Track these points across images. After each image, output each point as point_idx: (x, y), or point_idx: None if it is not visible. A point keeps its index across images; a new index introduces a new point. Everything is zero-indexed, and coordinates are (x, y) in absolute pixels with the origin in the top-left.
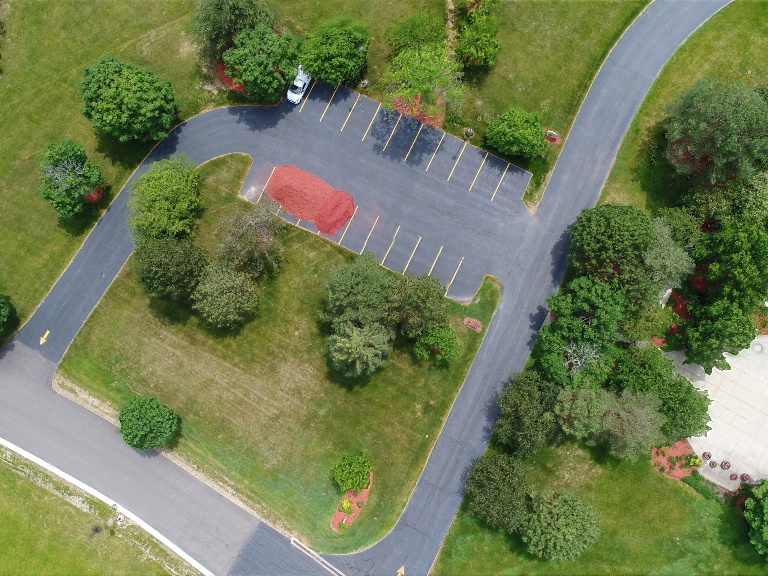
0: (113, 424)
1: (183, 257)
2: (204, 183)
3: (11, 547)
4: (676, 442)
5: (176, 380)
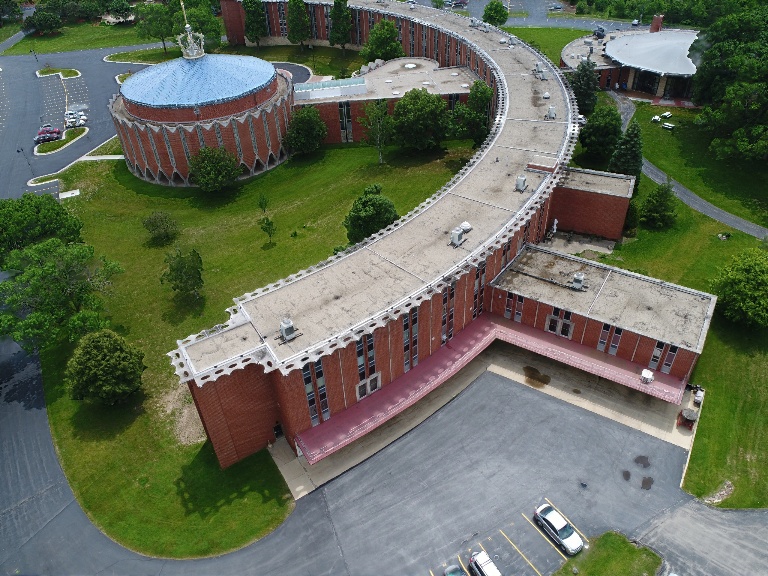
0: None
1: None
2: None
3: None
4: None
5: None
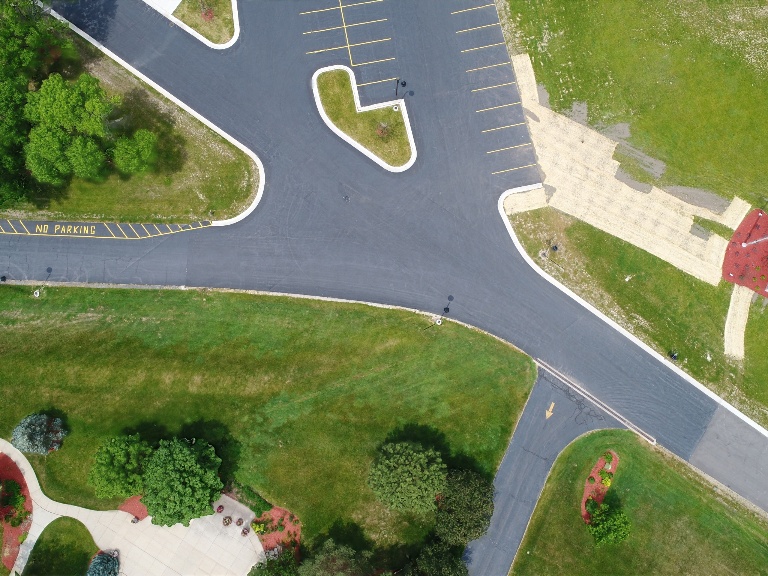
0: None
1: None
2: None
3: None
4: None
5: None
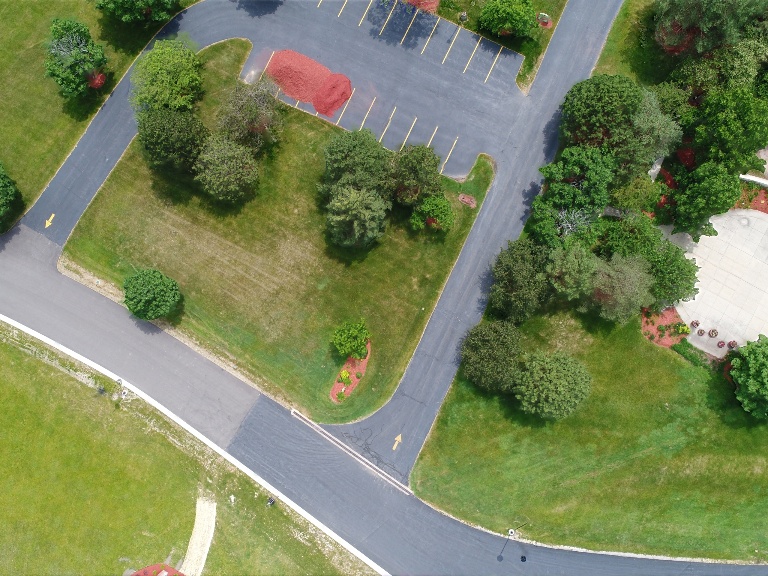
0: (117, 303)
1: (185, 125)
2: (205, 67)
3: (19, 420)
4: (665, 311)
5: (178, 259)
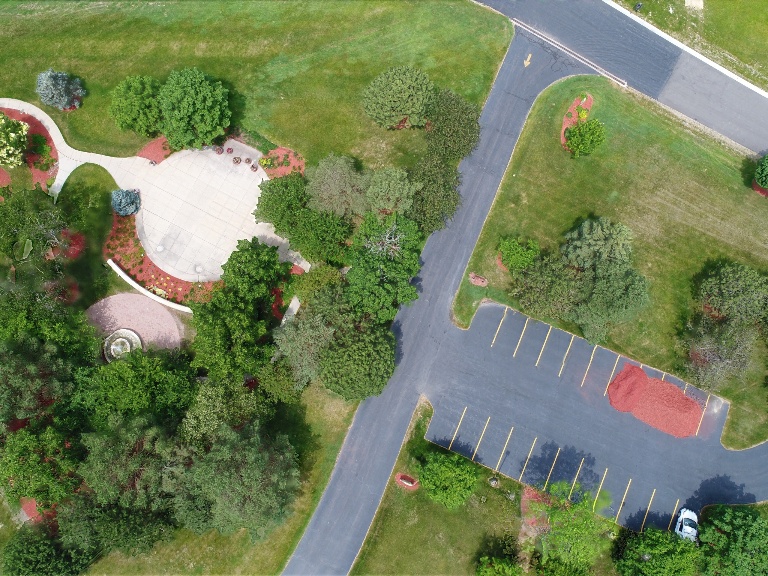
0: None
1: None
2: None
3: None
4: None
5: (757, 219)
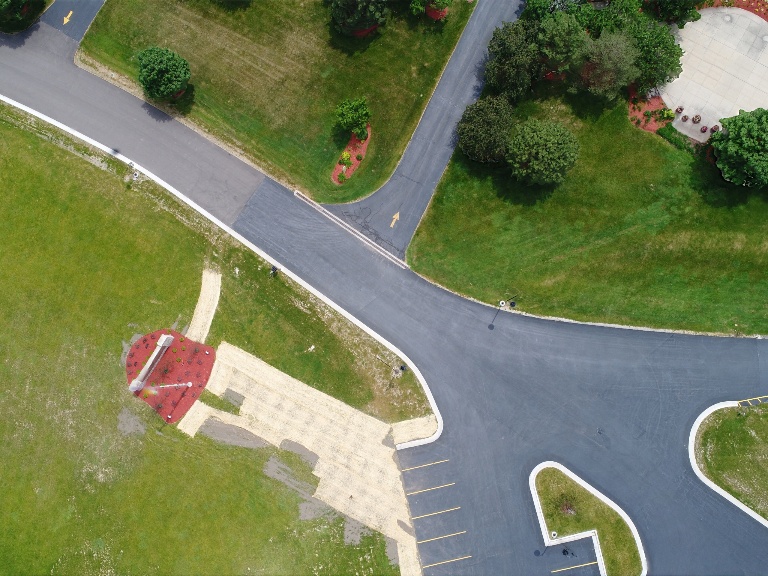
0: (130, 93)
1: None
2: None
3: (34, 198)
4: None
5: (190, 50)
